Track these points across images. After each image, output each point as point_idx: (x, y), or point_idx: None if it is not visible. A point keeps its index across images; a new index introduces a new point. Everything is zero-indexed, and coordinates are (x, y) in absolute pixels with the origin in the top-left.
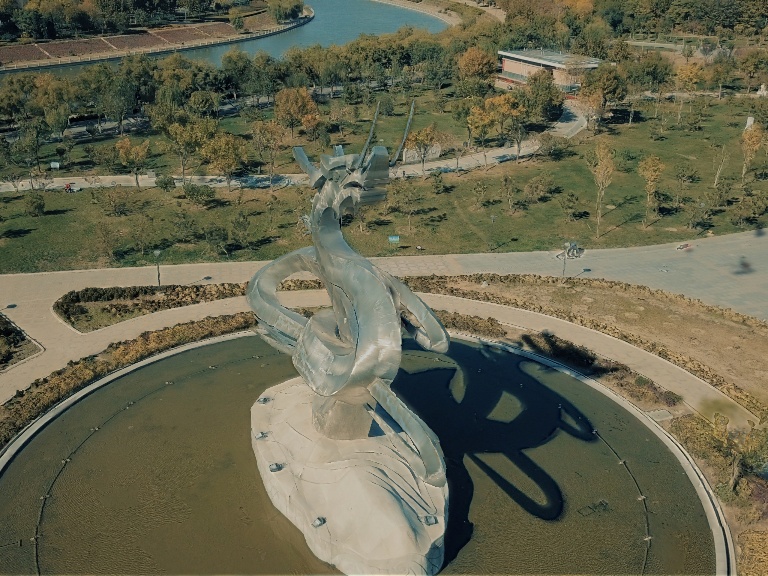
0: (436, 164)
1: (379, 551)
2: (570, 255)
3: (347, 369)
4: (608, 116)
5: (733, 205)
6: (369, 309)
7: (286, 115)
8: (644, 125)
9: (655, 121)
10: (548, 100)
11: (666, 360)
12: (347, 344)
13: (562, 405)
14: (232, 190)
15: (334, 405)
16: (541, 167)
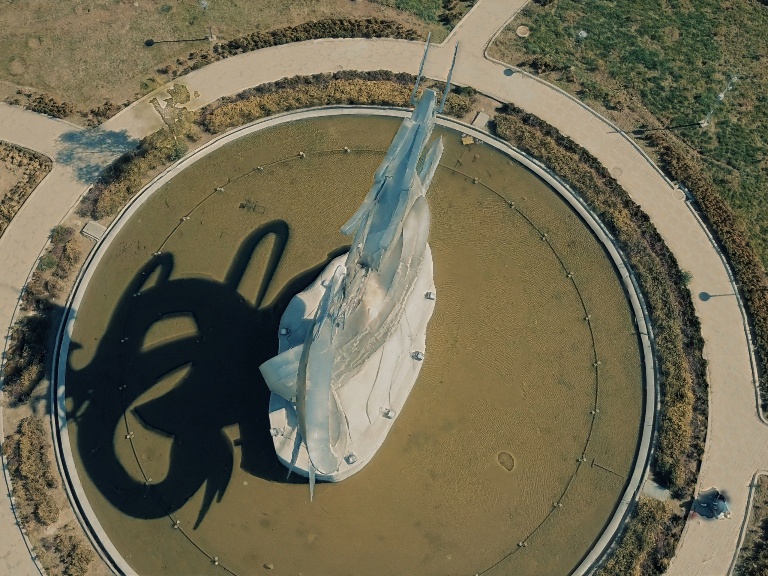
0: None
1: None
2: None
3: None
4: None
5: None
6: None
7: None
8: None
9: None
10: None
11: None
12: (369, 281)
13: (136, 294)
14: None
15: None
16: None
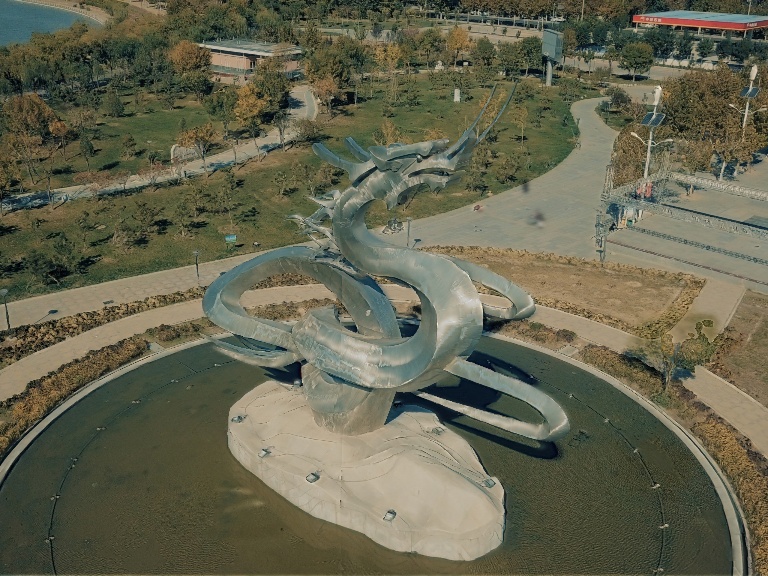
0: (206, 161)
1: (468, 523)
2: (393, 229)
3: (415, 356)
4: (345, 98)
5: (489, 167)
6: (445, 291)
7: (22, 125)
8: (368, 104)
9: (386, 99)
10: (281, 88)
11: (539, 305)
12: (374, 336)
13: (490, 360)
14: (5, 214)
15: (365, 399)
16: (308, 152)
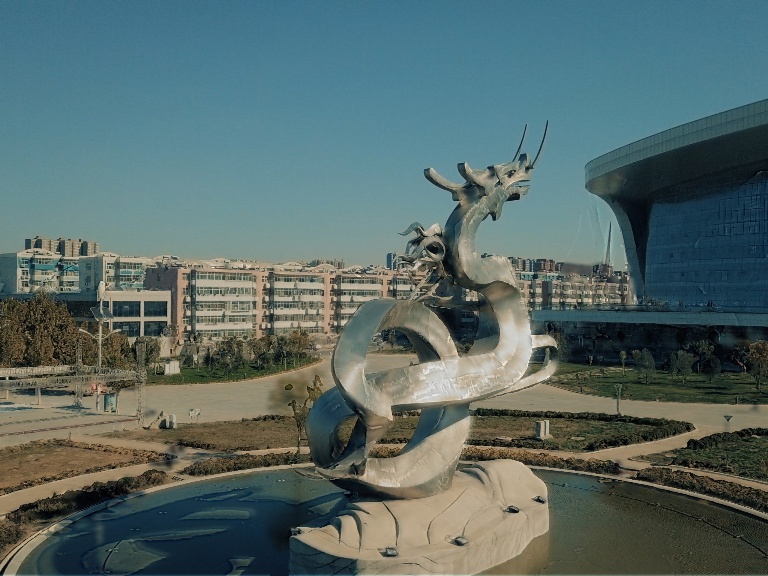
0: None
1: None
2: None
3: (517, 343)
4: None
5: None
6: None
7: None
8: None
9: None
10: None
11: (66, 478)
12: None
13: (198, 498)
14: None
15: None
16: None
